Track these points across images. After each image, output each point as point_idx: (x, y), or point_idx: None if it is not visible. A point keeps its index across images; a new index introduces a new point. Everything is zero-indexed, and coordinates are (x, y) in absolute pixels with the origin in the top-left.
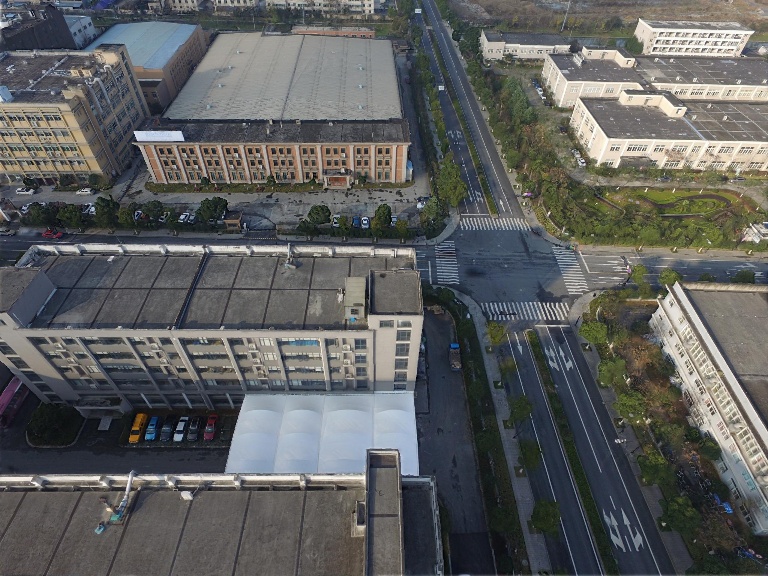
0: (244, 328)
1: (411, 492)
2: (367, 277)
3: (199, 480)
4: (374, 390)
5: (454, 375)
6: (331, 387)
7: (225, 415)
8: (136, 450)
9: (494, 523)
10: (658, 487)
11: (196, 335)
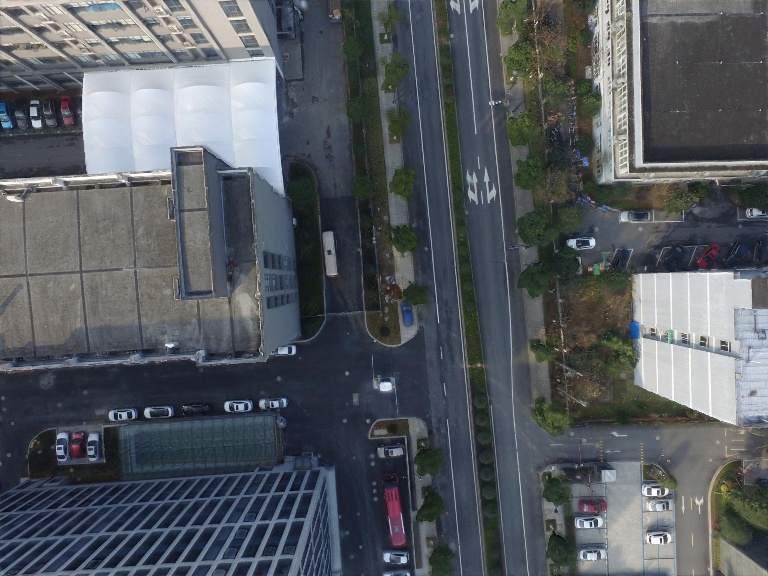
0: None
1: (233, 182)
2: None
3: (22, 184)
4: (228, 58)
5: (333, 28)
6: (176, 58)
7: (79, 95)
8: (0, 139)
9: (353, 191)
10: (527, 145)
11: None
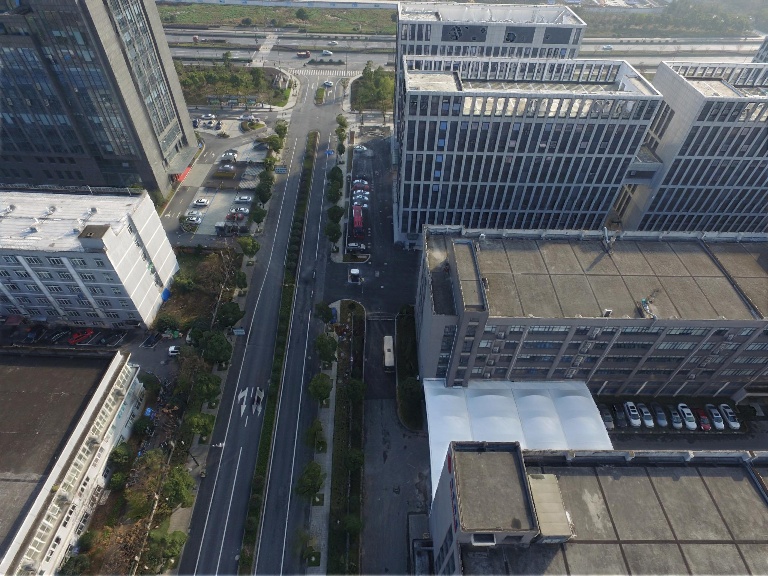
0: (668, 469)
1: None
2: (540, 575)
3: None
4: None
5: (372, 575)
6: None
7: None
8: None
9: None
10: None
11: (717, 456)
